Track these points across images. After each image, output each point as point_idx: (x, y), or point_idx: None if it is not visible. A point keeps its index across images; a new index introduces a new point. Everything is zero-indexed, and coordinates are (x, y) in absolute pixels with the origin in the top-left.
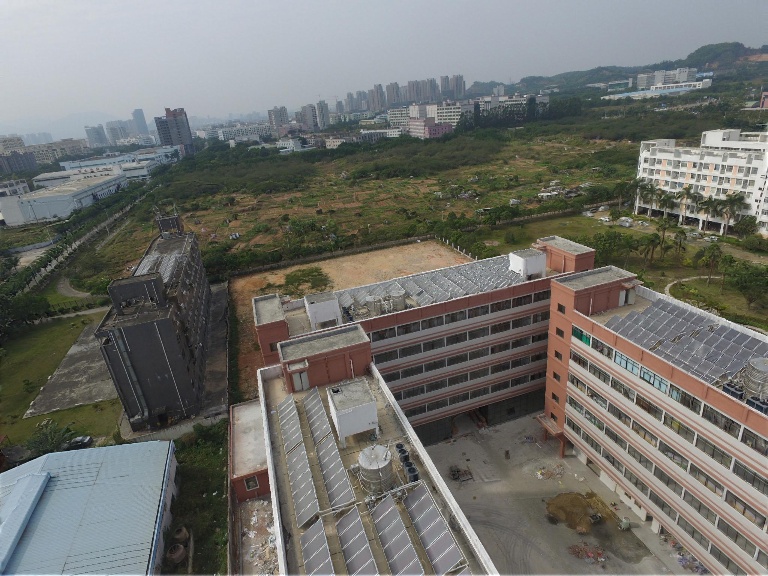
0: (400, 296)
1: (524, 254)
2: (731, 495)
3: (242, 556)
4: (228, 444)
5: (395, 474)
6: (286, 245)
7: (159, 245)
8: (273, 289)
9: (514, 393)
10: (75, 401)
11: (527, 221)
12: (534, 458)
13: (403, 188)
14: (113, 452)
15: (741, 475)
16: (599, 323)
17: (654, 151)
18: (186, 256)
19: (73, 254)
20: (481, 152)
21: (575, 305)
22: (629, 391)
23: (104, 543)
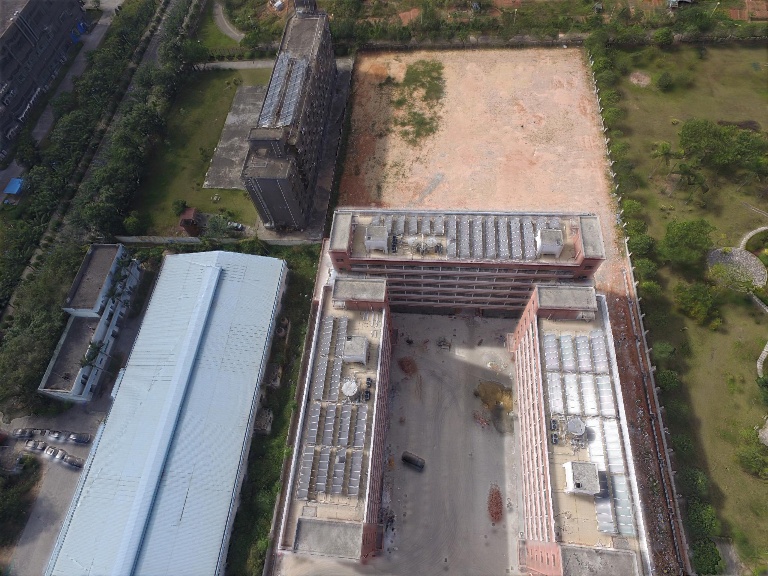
0: (432, 247)
1: (548, 237)
2: None
3: None
4: (318, 265)
5: (361, 391)
6: None
7: (292, 32)
8: (390, 89)
9: (507, 308)
10: (232, 183)
11: (719, 43)
12: (495, 352)
13: None
14: (252, 260)
15: None
16: None
17: None
18: (311, 70)
19: None
20: None
21: (537, 313)
22: None
23: (247, 321)
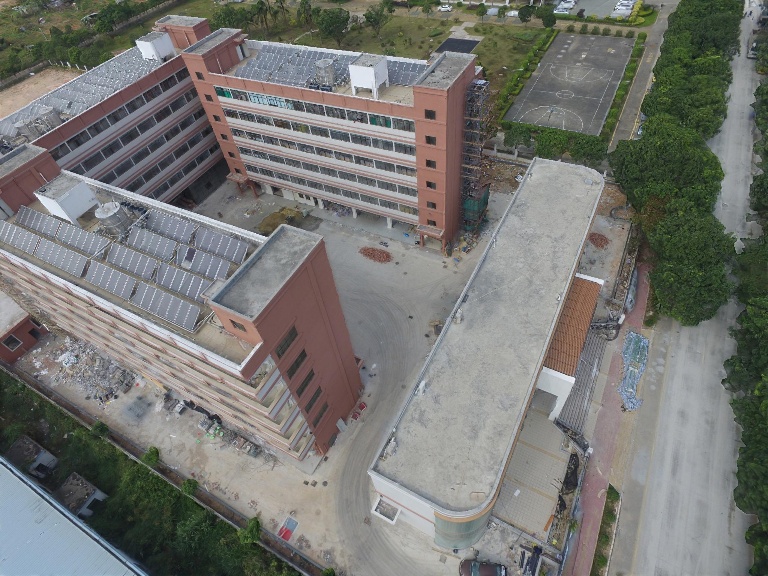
0: (50, 112)
1: (149, 38)
2: (336, 153)
3: (47, 387)
4: None
5: None
6: None
7: None
8: None
9: (203, 169)
10: None
11: (145, 19)
12: (239, 208)
13: None
14: None
15: (335, 137)
16: (229, 76)
17: None
18: None
19: None
20: None
21: (207, 68)
22: (268, 119)
23: None
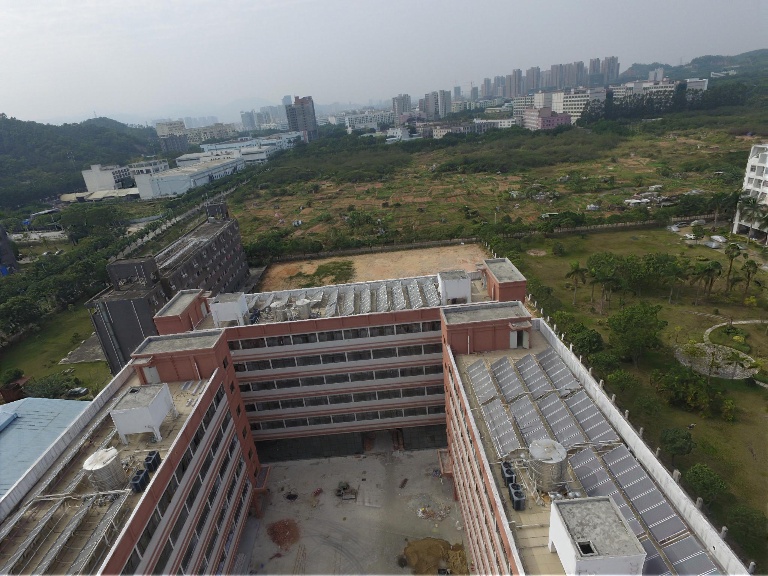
0: (302, 305)
1: (450, 276)
2: None
3: None
4: None
5: None
6: (333, 236)
7: (201, 229)
8: (300, 278)
9: (433, 421)
10: (98, 357)
11: (594, 231)
12: (428, 493)
13: (483, 184)
14: (73, 406)
15: None
16: None
17: (764, 158)
18: (209, 241)
19: (170, 228)
20: (589, 148)
21: (449, 340)
22: None
23: None
